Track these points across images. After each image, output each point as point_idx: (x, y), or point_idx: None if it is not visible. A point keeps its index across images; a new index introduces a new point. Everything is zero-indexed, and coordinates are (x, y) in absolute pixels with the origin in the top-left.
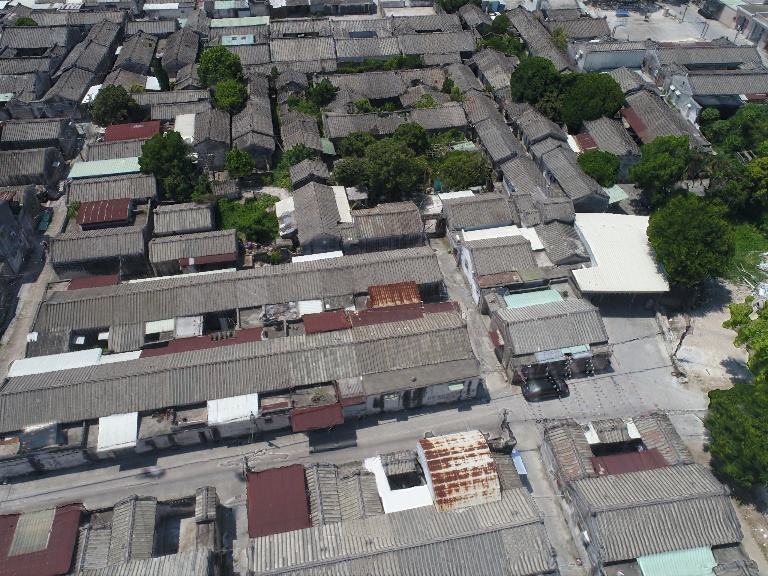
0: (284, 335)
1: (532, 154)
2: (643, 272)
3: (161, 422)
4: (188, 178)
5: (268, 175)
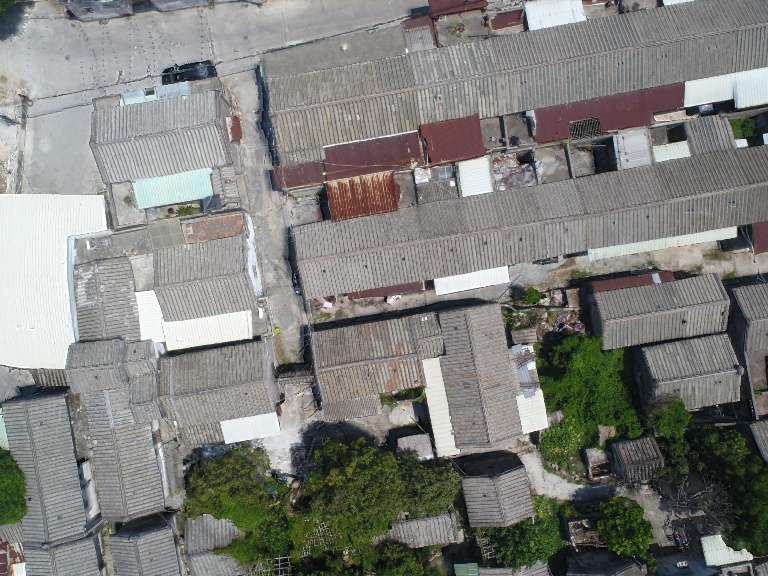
0: (507, 127)
1: (101, 575)
2: (7, 225)
3: (634, 3)
4: (707, 462)
5: (570, 520)
